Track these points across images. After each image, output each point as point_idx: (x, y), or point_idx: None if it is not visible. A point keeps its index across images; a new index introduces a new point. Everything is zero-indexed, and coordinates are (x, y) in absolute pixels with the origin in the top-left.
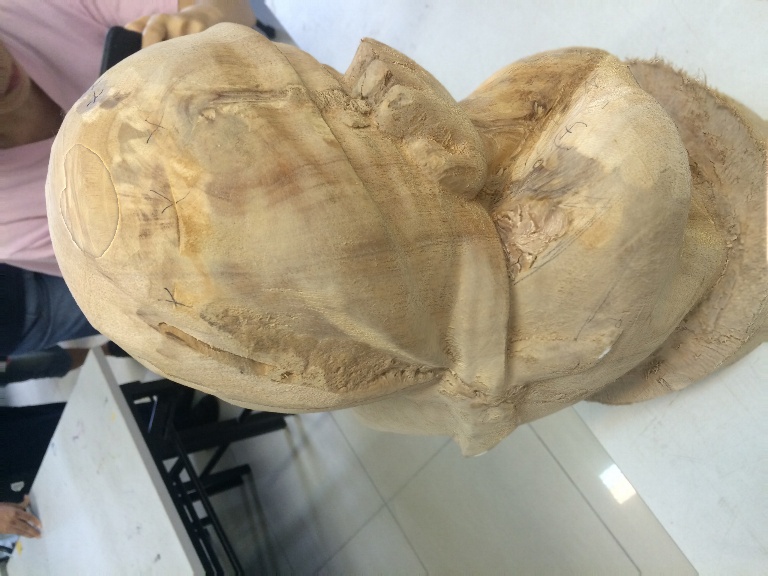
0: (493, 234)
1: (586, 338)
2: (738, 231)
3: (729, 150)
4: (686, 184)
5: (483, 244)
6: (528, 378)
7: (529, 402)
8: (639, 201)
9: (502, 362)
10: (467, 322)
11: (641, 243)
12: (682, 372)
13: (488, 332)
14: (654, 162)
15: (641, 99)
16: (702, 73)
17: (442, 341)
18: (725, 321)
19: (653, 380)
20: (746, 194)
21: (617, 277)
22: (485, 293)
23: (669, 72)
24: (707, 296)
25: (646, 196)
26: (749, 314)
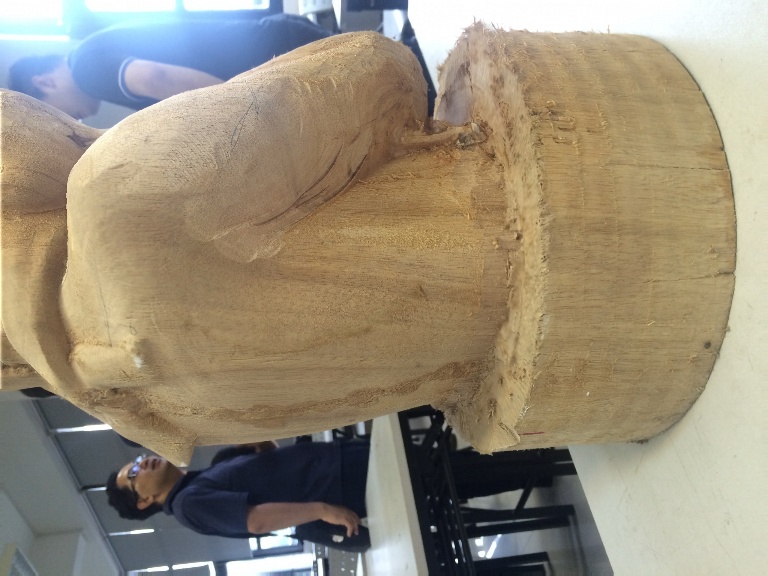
0: (41, 243)
1: (118, 345)
2: (518, 227)
3: (514, 120)
4: (167, 177)
5: (14, 252)
6: (95, 382)
7: (166, 413)
8: (76, 201)
9: (45, 362)
10: (2, 322)
11: (93, 244)
12: (505, 416)
13: (19, 332)
14: (107, 159)
15: (213, 89)
16: (497, 27)
17: (5, 339)
18: (520, 349)
19: (495, 424)
20: (521, 176)
21: (97, 280)
22: (9, 296)
23: None
24: (505, 315)
25: (80, 195)
26: (532, 340)
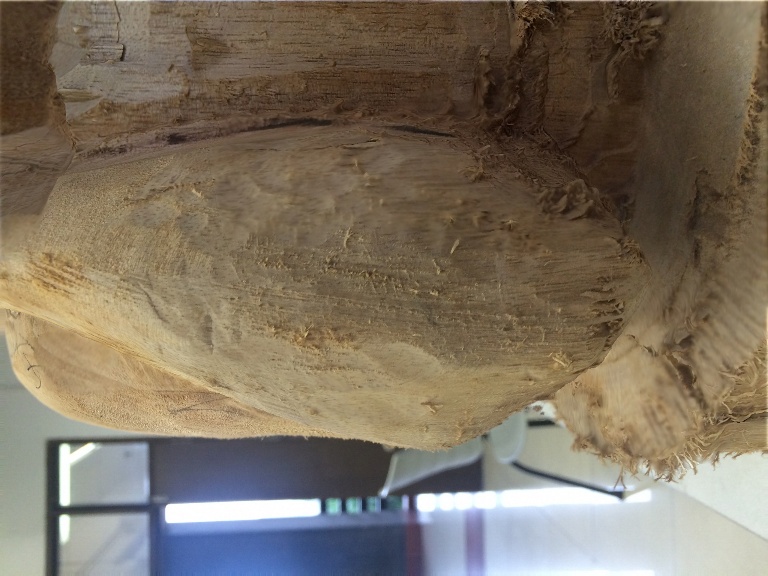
0: None
1: None
2: None
3: None
4: None
5: None
6: None
7: None
8: None
9: None
10: None
11: None
12: None
13: None
14: None
15: None
16: None
17: None
18: None
19: None
20: None
21: None
22: None
23: (650, 453)
24: None
25: None
26: None
